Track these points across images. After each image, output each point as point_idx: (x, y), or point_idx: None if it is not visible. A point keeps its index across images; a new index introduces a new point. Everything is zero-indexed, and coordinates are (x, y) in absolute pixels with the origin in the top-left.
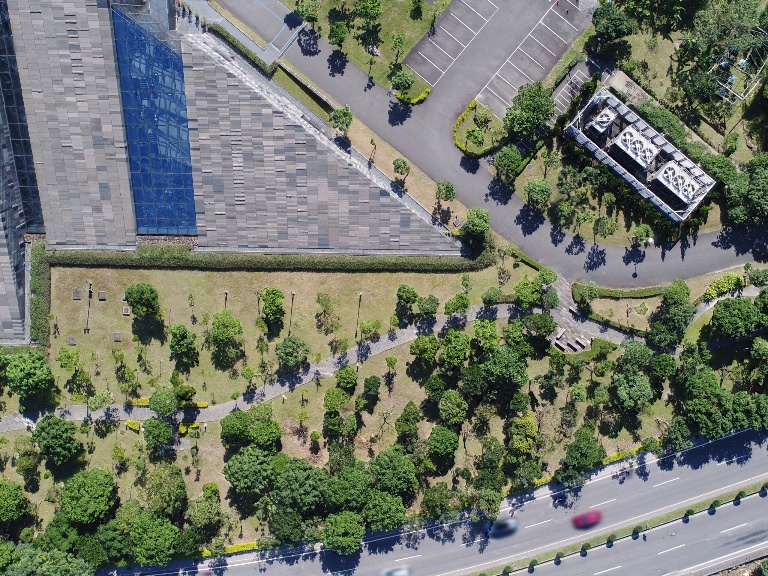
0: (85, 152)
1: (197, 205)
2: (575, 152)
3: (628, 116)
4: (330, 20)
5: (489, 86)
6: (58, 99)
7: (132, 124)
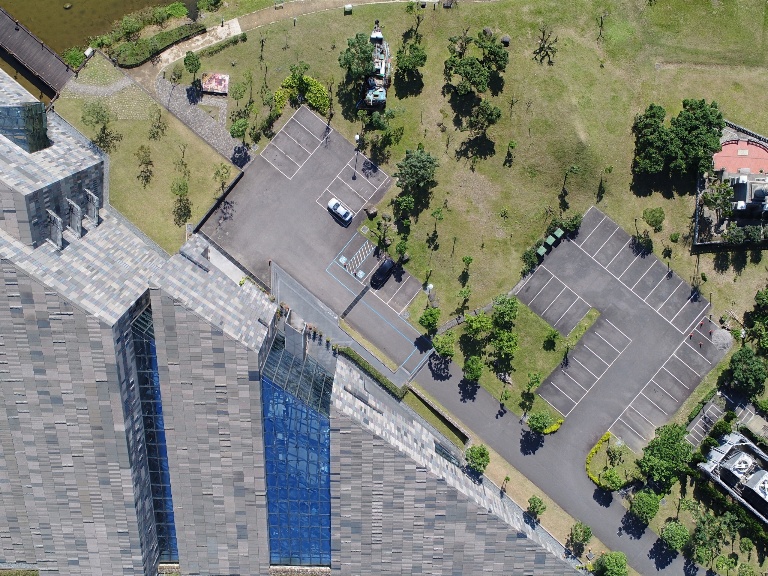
0: (225, 499)
1: (333, 544)
2: (711, 493)
3: (764, 457)
4: (461, 345)
5: (622, 418)
6: (202, 455)
7: (273, 473)
